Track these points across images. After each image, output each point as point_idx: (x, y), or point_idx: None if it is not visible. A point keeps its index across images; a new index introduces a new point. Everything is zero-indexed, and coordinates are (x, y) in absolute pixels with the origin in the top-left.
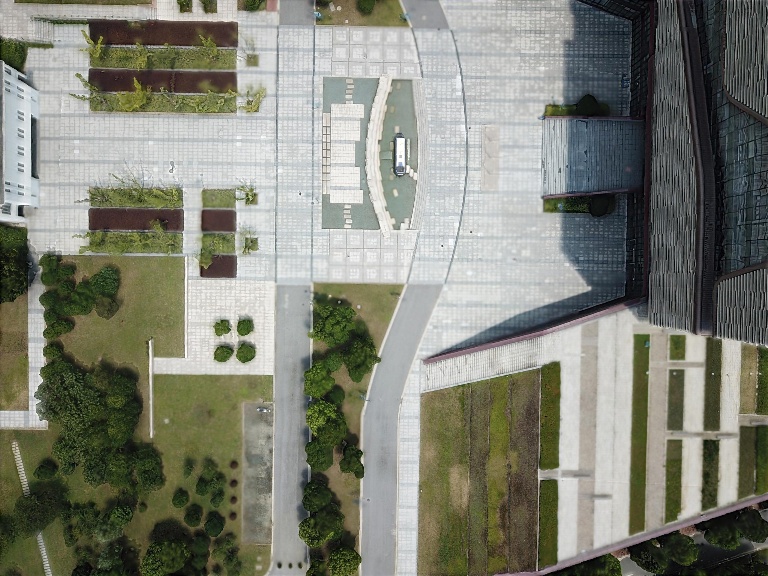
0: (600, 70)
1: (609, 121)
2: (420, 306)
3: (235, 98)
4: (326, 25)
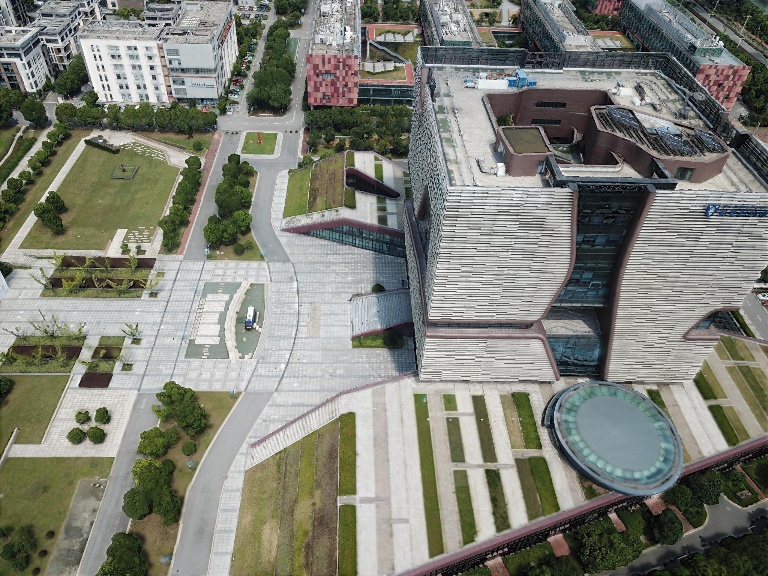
0: (387, 279)
1: (391, 294)
2: (253, 406)
3: (142, 291)
4: (212, 260)
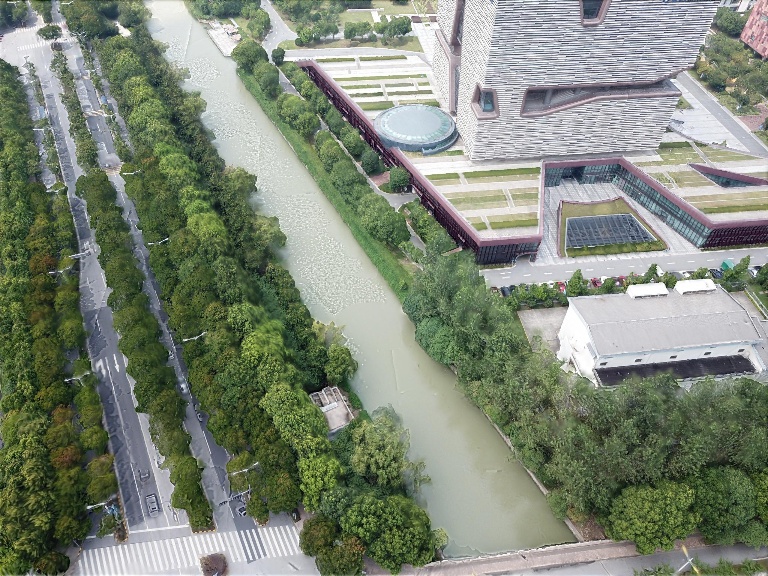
0: None
1: None
2: None
3: None
4: None
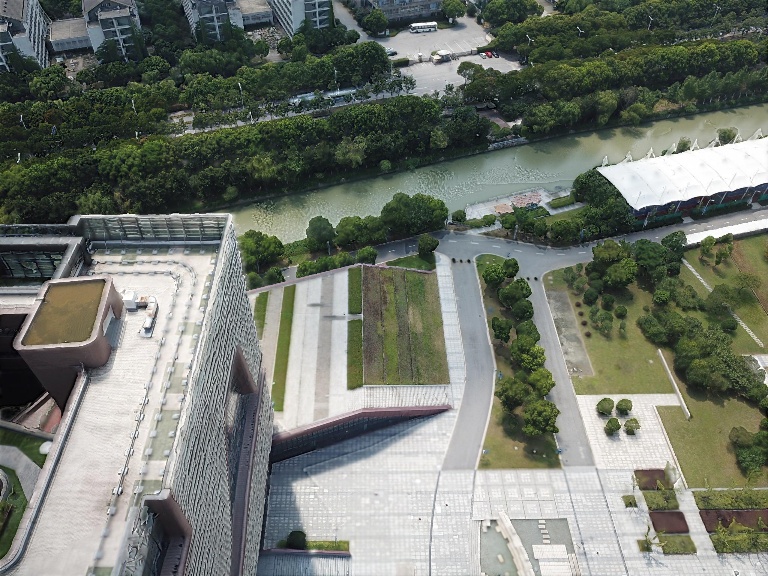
0: None
1: None
2: (460, 452)
3: None
4: None
